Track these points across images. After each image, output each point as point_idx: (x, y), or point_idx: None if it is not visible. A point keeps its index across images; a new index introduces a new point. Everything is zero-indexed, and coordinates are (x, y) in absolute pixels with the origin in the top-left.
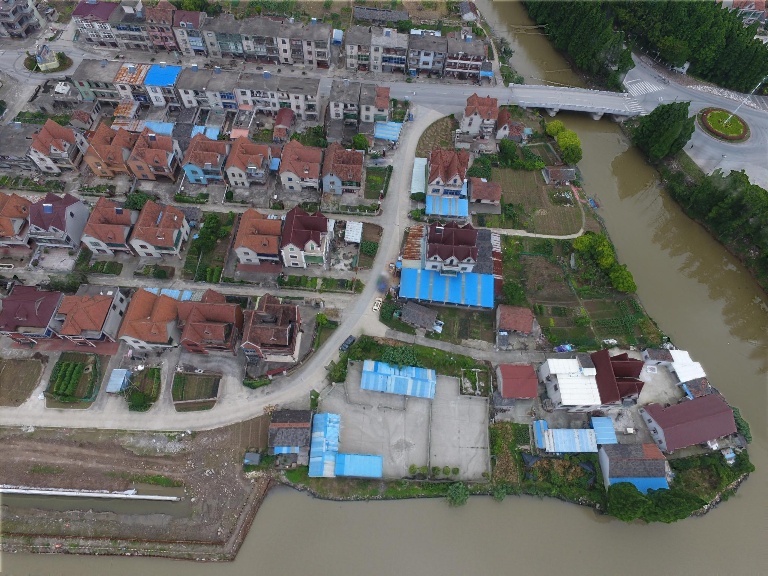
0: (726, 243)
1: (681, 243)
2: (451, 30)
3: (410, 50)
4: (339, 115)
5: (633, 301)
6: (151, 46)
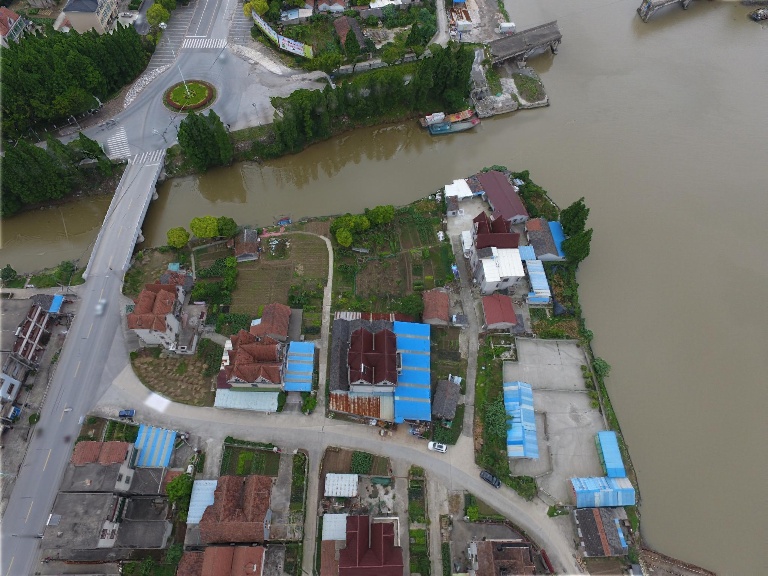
0: (332, 134)
1: (309, 167)
2: None
3: None
4: (113, 531)
5: (399, 212)
6: None
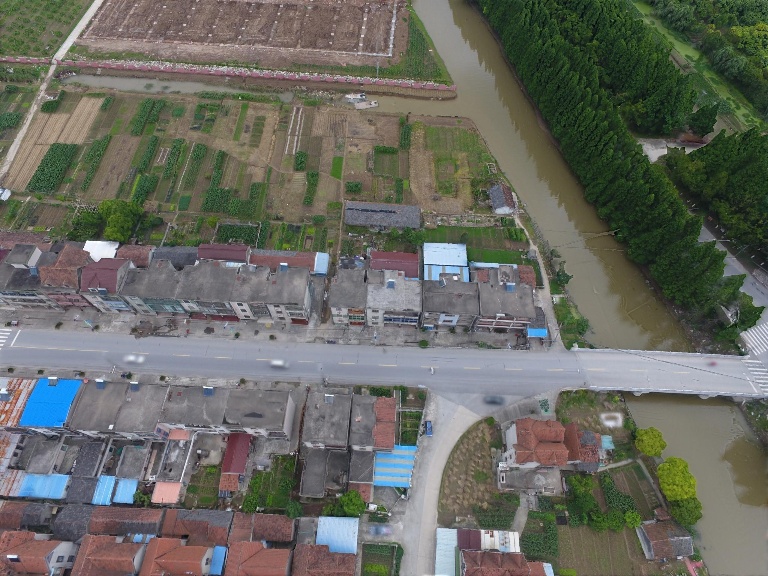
0: None
1: None
2: (479, 233)
3: (424, 312)
4: (319, 446)
5: None
6: (56, 305)
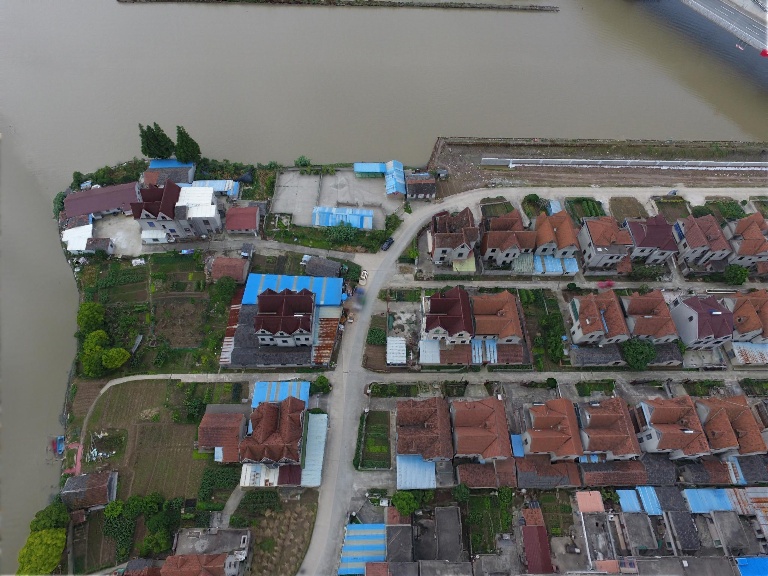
0: None
1: None
2: None
3: None
4: None
5: None
6: None
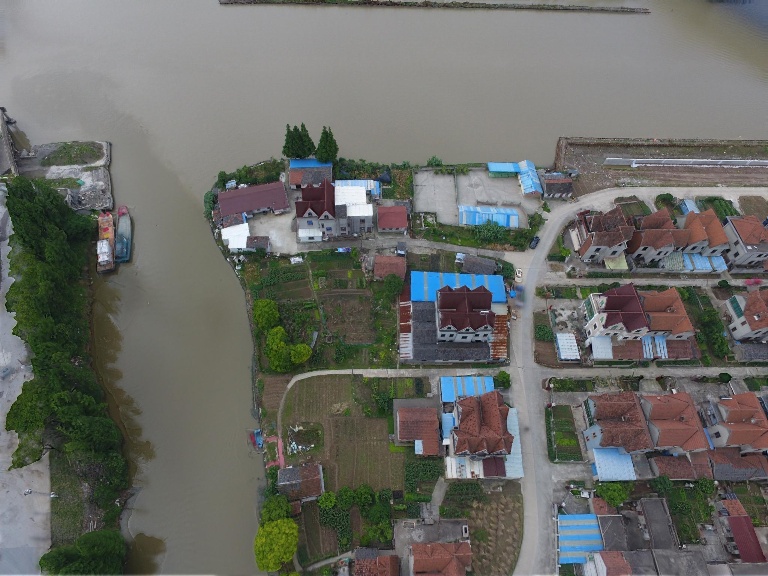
0: None
1: None
2: None
3: None
4: None
5: None
6: None
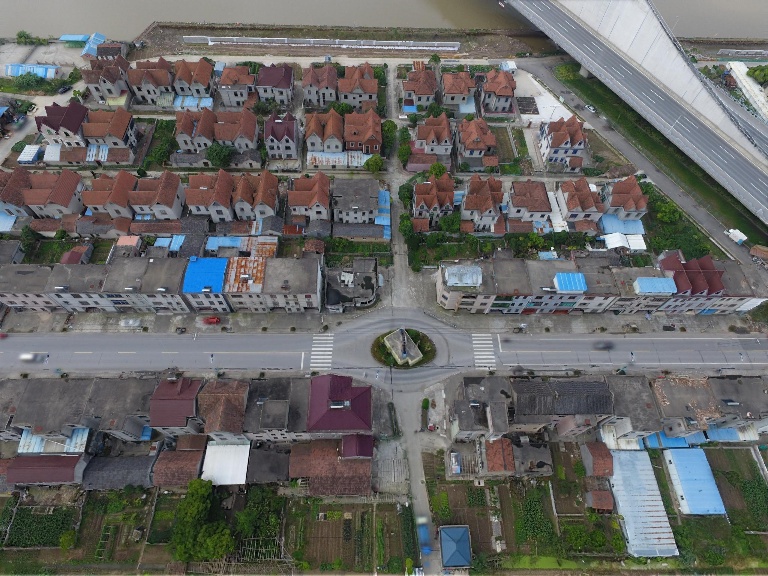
0: None
1: None
2: None
3: None
4: None
5: None
6: None
